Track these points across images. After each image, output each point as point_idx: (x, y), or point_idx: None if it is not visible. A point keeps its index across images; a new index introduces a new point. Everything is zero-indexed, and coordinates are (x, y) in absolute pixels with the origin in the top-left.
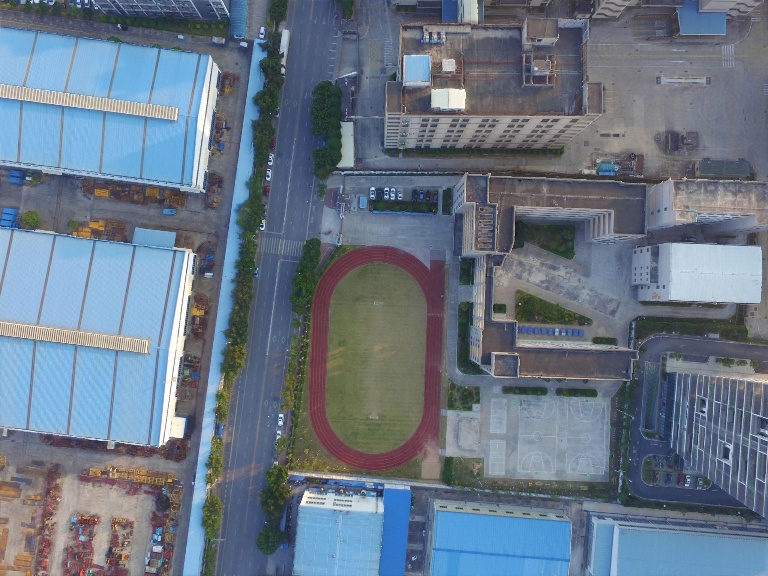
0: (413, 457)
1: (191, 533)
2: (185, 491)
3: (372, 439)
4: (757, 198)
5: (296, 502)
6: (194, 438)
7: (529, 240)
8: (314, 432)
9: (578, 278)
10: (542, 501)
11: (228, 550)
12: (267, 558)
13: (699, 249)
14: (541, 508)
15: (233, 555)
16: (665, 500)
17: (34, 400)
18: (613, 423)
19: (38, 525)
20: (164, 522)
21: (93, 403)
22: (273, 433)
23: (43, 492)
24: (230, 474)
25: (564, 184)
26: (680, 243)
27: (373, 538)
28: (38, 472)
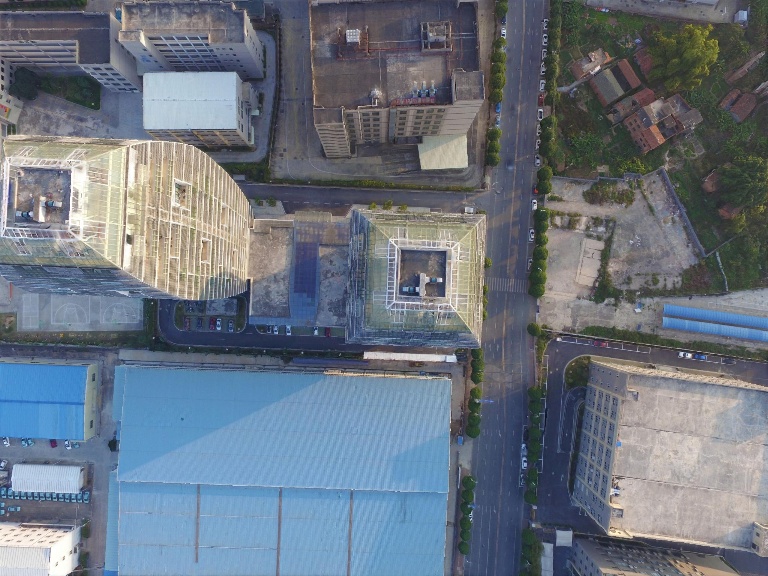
0: None
1: None
2: None
3: None
4: (212, 18)
5: None
6: None
7: (54, 93)
8: None
9: (106, 128)
10: (78, 353)
11: None
12: None
13: (172, 77)
14: (77, 359)
15: None
16: (198, 345)
17: None
18: None
19: None
20: None
21: None
22: None
23: None
24: None
25: (29, 18)
26: (153, 72)
27: None
28: None
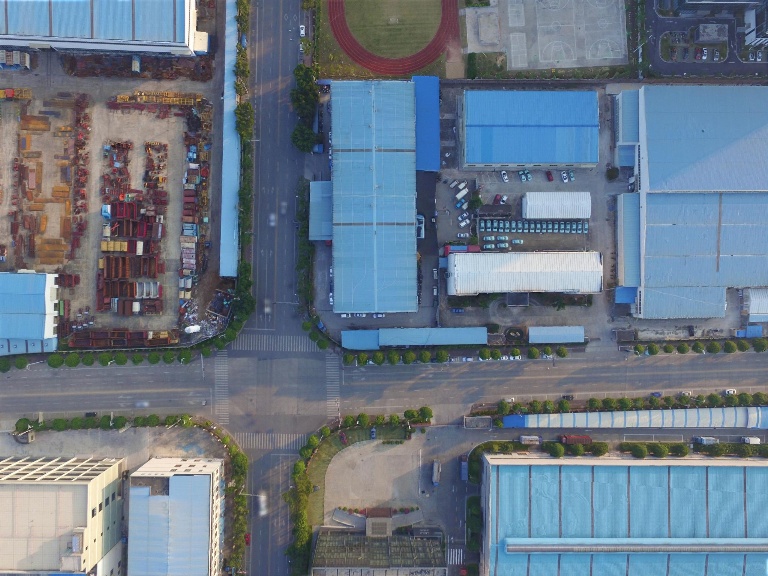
0: (436, 59)
1: (226, 141)
2: (215, 110)
3: (394, 44)
4: None
5: (326, 109)
6: (218, 58)
7: None
8: (336, 42)
9: None
10: (566, 89)
11: (264, 164)
12: (303, 168)
13: None
14: None
15: (269, 169)
16: None
17: (54, 3)
18: (628, 7)
19: (71, 156)
20: (197, 141)
21: (114, 2)
22: (296, 46)
23: (73, 123)
24: (258, 90)
25: None
26: None
27: (407, 107)
28: (65, 103)
